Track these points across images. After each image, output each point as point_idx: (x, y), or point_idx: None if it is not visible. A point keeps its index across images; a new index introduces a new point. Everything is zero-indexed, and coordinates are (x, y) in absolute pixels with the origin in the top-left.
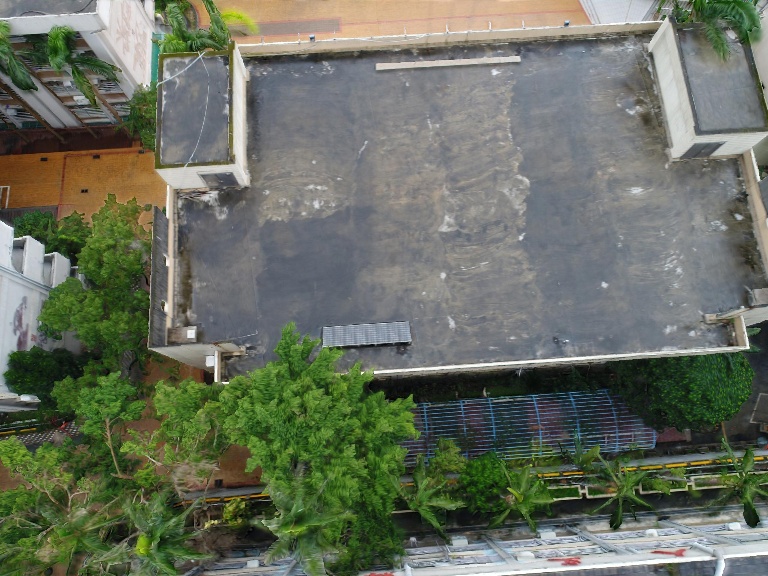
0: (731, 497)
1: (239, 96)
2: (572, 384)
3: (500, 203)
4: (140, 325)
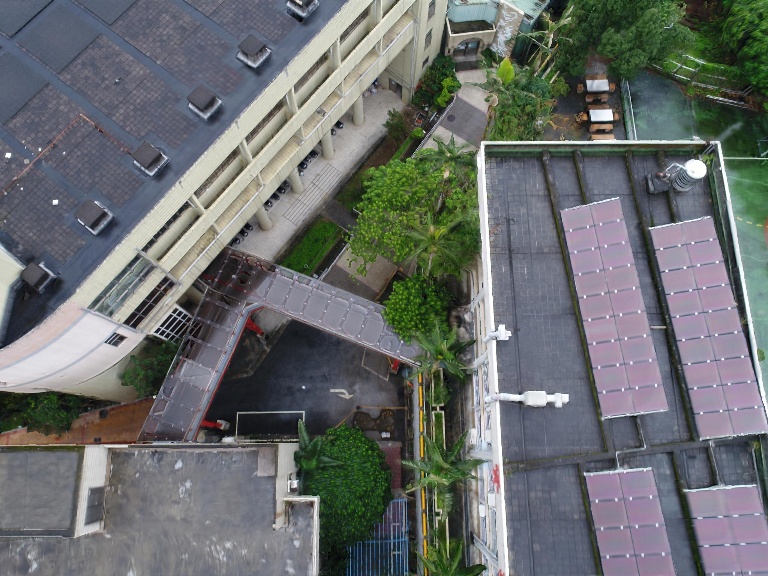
0: None
1: None
2: (338, 575)
3: None
4: None
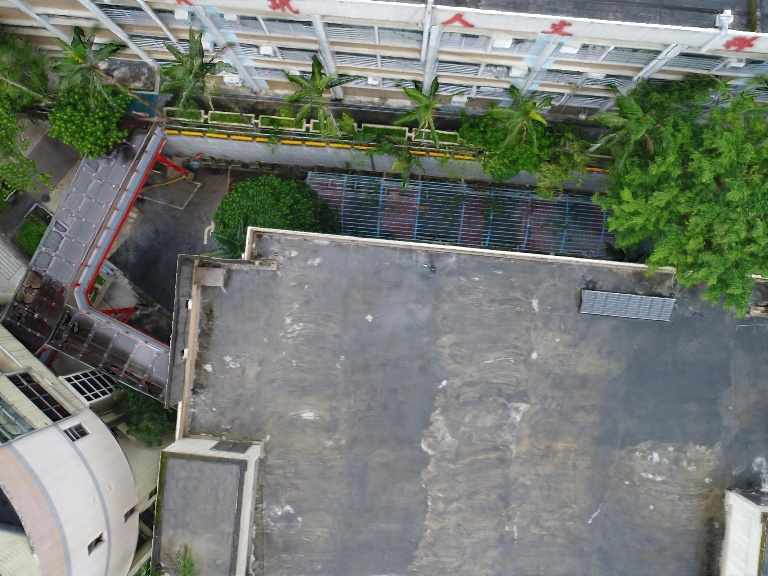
0: (268, 109)
1: None
2: None
3: (458, 426)
4: None
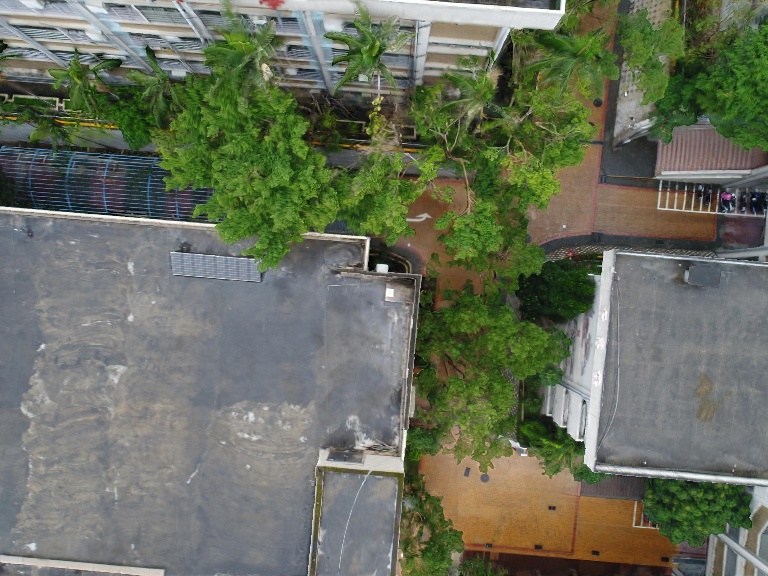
0: None
1: None
2: None
3: (57, 388)
4: (452, 318)
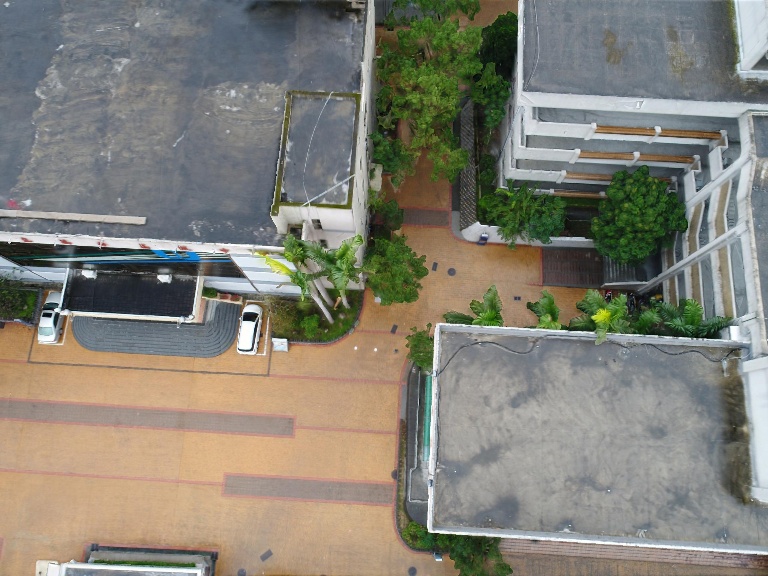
0: None
1: None
2: None
3: (69, 77)
4: None
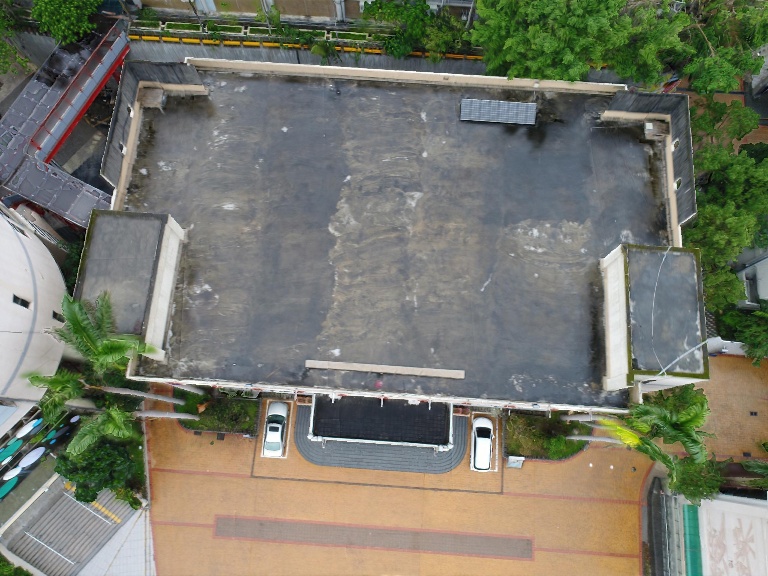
0: None
1: (615, 347)
2: None
3: (361, 211)
4: None
